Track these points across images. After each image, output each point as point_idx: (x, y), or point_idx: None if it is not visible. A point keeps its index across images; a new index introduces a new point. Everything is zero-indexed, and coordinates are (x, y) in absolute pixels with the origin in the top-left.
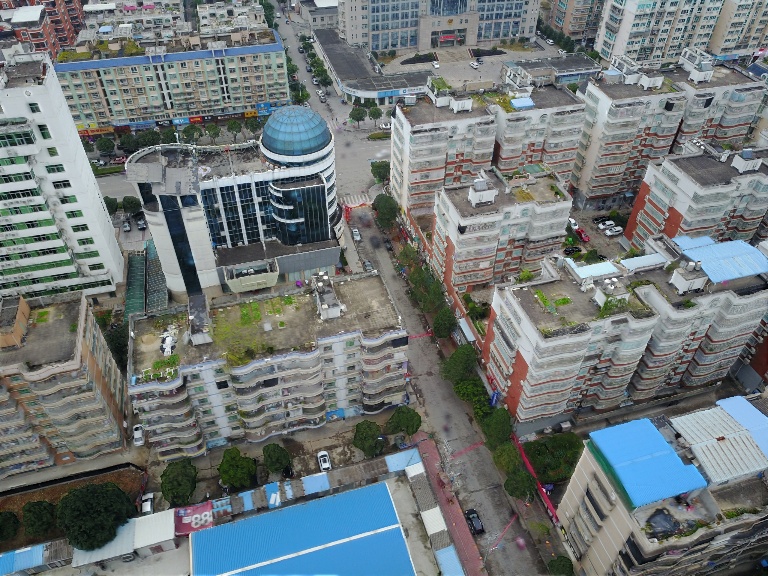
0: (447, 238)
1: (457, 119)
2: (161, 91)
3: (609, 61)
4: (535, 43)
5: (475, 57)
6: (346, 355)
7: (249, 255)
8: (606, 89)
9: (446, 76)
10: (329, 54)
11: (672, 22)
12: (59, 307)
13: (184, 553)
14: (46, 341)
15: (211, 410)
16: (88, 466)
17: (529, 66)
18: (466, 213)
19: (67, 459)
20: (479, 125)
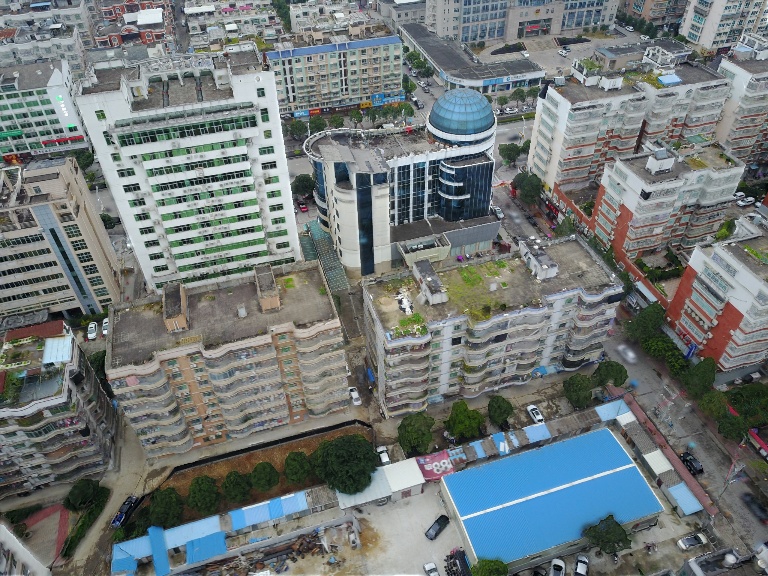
0: (621, 206)
1: (612, 96)
2: (286, 85)
3: (697, 44)
4: (615, 30)
5: (561, 45)
6: (563, 312)
7: (417, 231)
8: (740, 65)
9: (538, 64)
10: (424, 47)
11: (762, 4)
12: (299, 274)
13: (430, 497)
14: (301, 303)
15: (439, 367)
16: (316, 424)
17: (621, 51)
18: (648, 180)
19: (297, 418)
20: (632, 101)
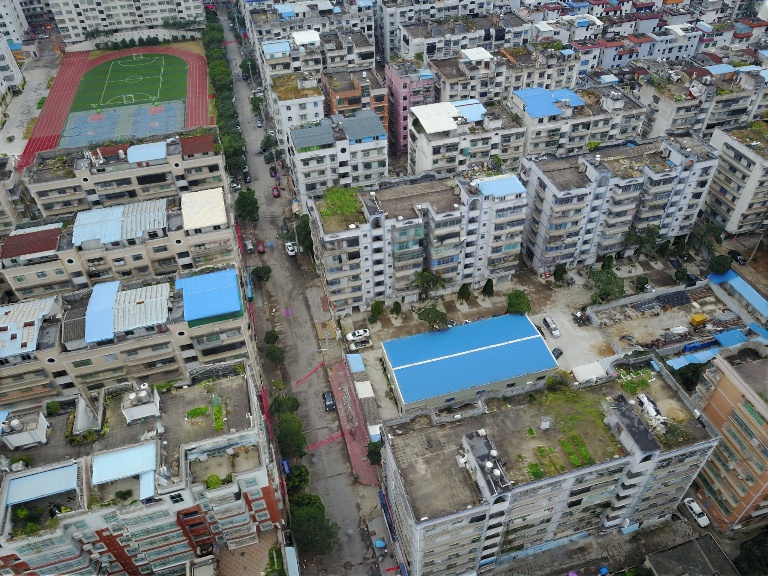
0: None
1: None
2: None
3: None
4: None
5: None
6: None
7: None
8: None
9: None
10: None
11: None
12: None
13: None
14: None
15: None
16: None
17: None
18: None
19: None
20: None
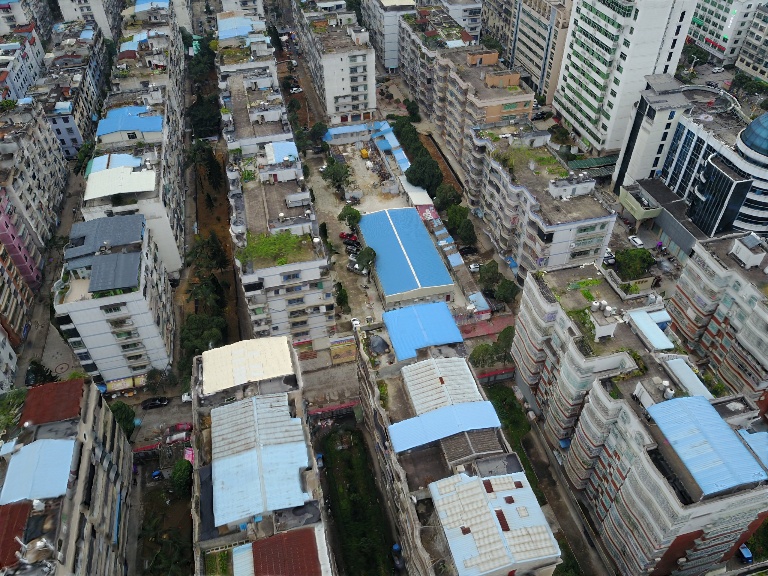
0: None
1: None
2: None
3: None
4: None
5: None
6: None
7: (661, 195)
8: None
9: None
10: None
11: None
12: (523, 92)
13: None
14: (494, 93)
15: None
16: (462, 177)
17: None
18: (714, 248)
19: None
20: None
